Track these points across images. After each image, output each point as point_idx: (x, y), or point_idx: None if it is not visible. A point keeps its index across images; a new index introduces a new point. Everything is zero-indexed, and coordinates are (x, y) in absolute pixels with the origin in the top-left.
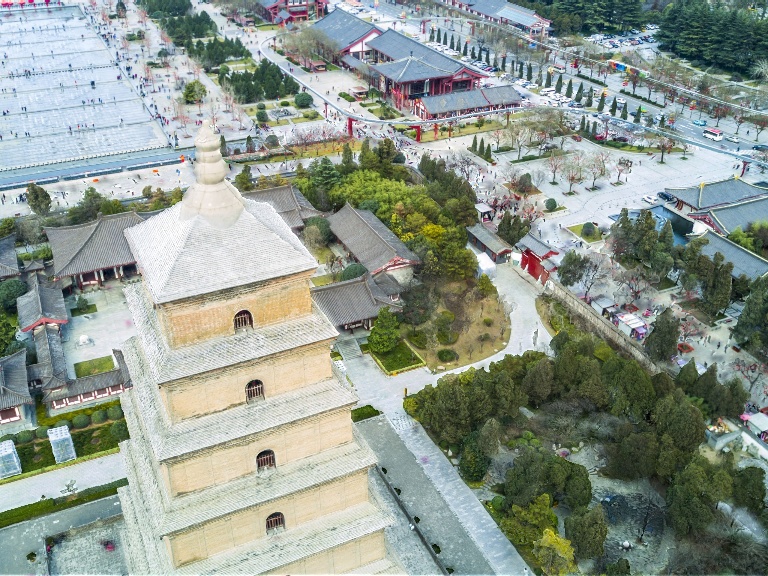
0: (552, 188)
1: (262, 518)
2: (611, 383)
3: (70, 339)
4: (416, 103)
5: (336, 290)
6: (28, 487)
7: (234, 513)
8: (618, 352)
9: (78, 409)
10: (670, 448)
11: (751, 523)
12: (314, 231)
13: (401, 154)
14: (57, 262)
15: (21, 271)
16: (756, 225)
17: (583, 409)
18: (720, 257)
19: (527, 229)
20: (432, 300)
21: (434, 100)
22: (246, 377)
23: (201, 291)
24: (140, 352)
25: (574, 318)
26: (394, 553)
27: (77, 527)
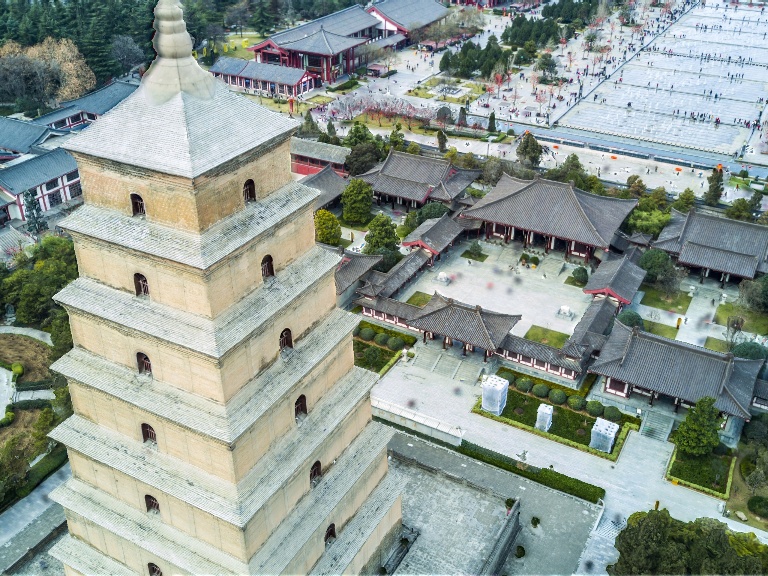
0: None
1: (138, 421)
2: None
3: (437, 271)
4: None
5: (684, 352)
6: None
7: None
8: None
9: (378, 324)
10: None
11: None
12: (752, 287)
13: None
14: (478, 203)
15: (457, 201)
16: None
17: None
18: None
19: None
20: None
21: None
22: (133, 266)
23: (92, 152)
24: None
25: None
26: (272, 572)
27: None
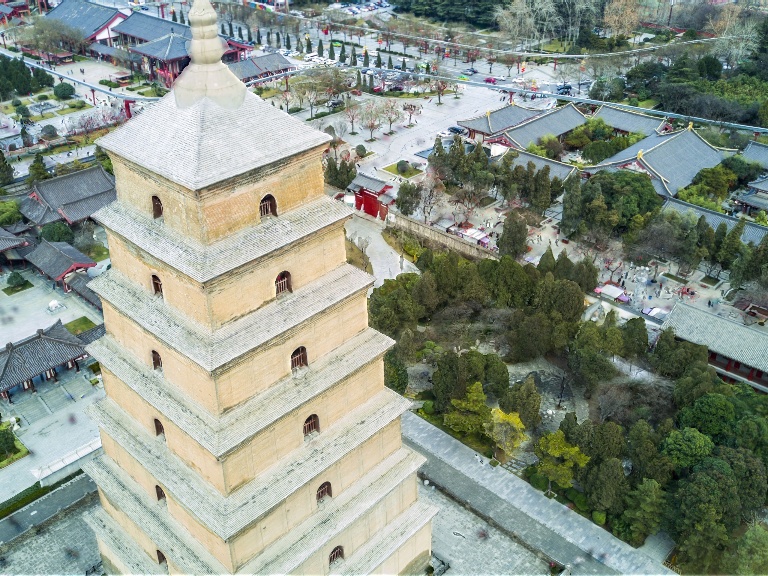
0: (354, 138)
1: (300, 423)
2: (491, 281)
3: None
4: None
5: None
6: None
7: (278, 421)
8: (476, 261)
9: None
10: (561, 322)
11: (645, 365)
12: None
13: None
14: None
15: None
16: (545, 138)
17: (473, 309)
18: (532, 165)
19: (355, 171)
20: None
21: None
22: (276, 269)
23: (235, 172)
24: (123, 283)
25: (425, 241)
26: (403, 444)
27: (8, 541)
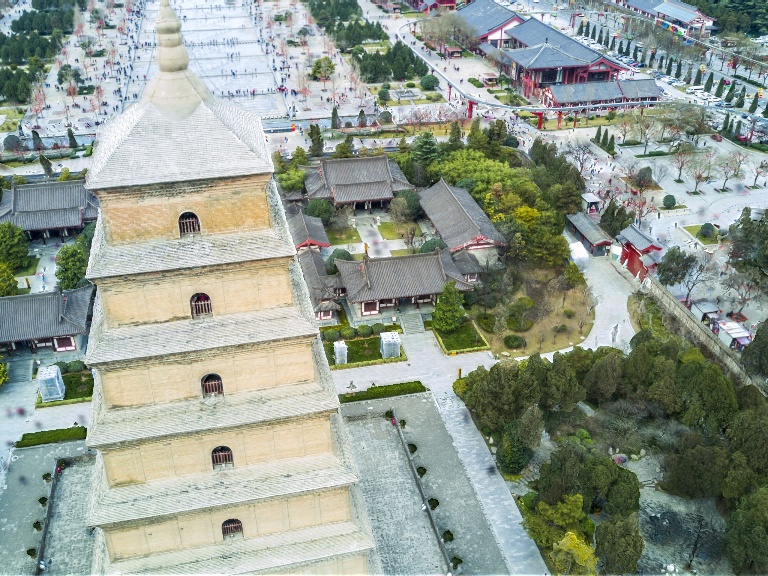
0: (676, 186)
1: (207, 449)
2: (686, 388)
3: None
4: (545, 91)
5: (406, 261)
6: (66, 413)
7: (173, 437)
8: (709, 360)
9: None
10: (742, 468)
11: None
12: (401, 203)
13: (514, 138)
14: None
15: None
16: None
17: (649, 413)
18: None
19: (631, 221)
20: (506, 281)
21: (564, 89)
22: (190, 288)
23: (137, 182)
24: None
25: (667, 319)
26: (365, 519)
27: (90, 454)
